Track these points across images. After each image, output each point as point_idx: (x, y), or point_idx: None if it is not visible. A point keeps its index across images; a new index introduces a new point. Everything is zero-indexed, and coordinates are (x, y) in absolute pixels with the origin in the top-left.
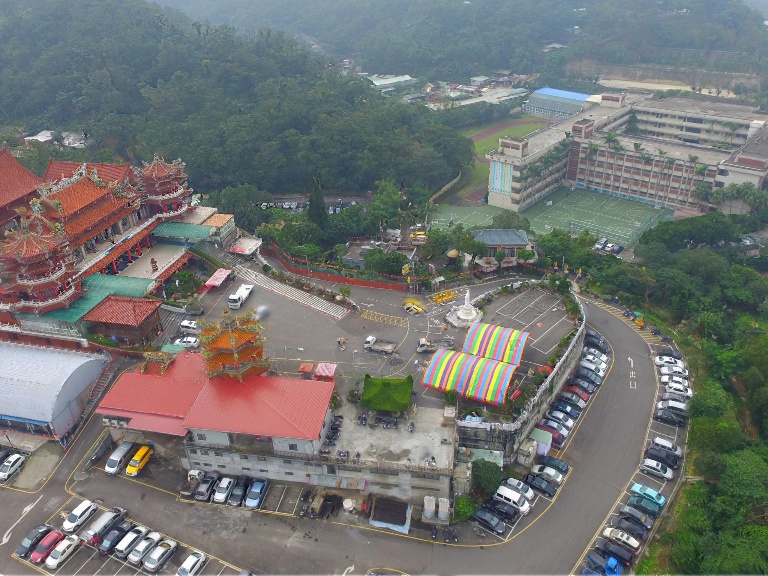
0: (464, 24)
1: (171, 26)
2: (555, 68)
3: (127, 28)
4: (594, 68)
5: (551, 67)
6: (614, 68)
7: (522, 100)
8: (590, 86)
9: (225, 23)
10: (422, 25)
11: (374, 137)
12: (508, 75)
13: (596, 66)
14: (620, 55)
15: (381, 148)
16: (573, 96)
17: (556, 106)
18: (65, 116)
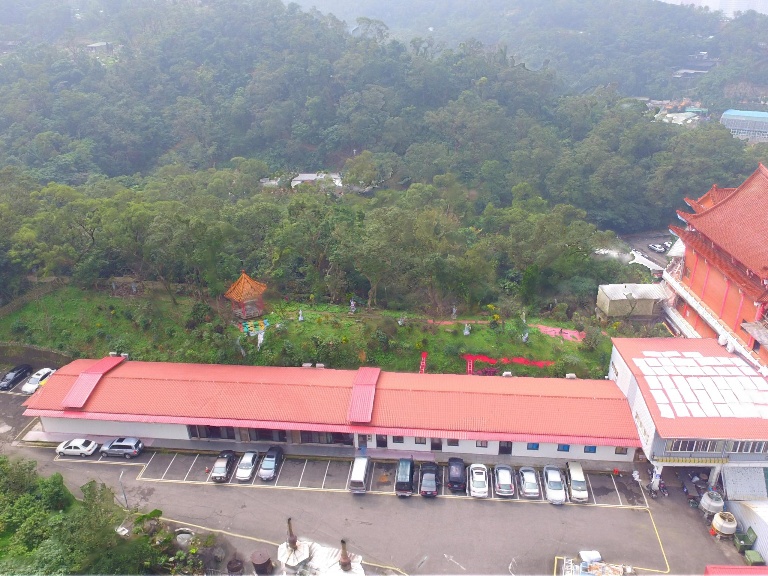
0: (588, 51)
1: (392, 42)
2: (718, 91)
3: (355, 43)
4: (749, 90)
5: (714, 90)
6: None
7: None
8: (761, 107)
9: (472, 37)
10: (539, 53)
11: (751, 157)
12: (648, 101)
13: (751, 88)
14: None
15: None
16: None
17: (761, 126)
18: None
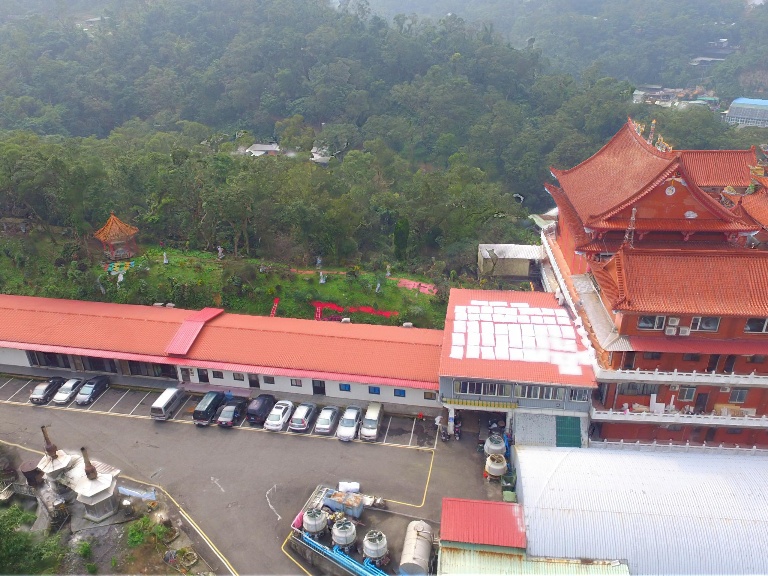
0: (600, 37)
1: (374, 18)
2: (732, 79)
3: None
4: (767, 79)
5: (728, 78)
6: None
7: (719, 111)
8: None
9: None
10: (550, 38)
11: None
12: (661, 89)
13: None
14: None
15: None
16: None
17: None
18: (269, 125)
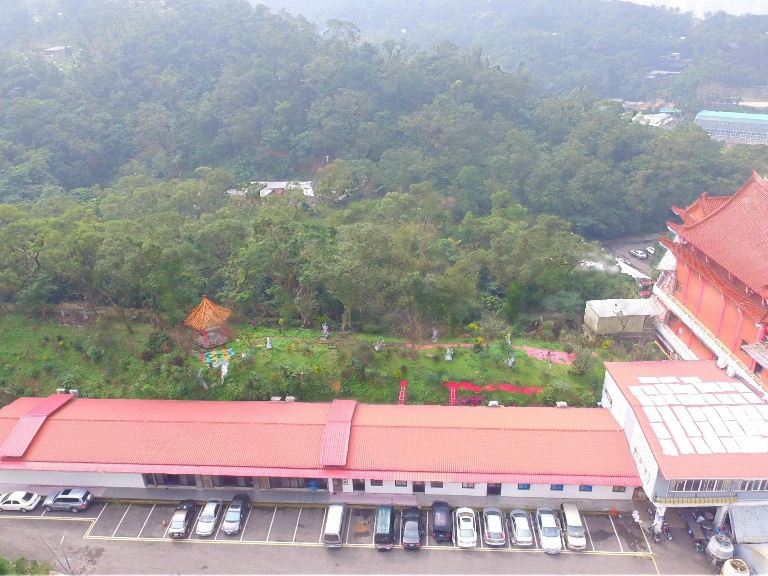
0: (561, 53)
1: (364, 45)
2: (691, 92)
3: (326, 46)
4: (722, 91)
5: (687, 91)
6: (744, 90)
7: None
8: (734, 108)
9: None
10: (512, 55)
11: (729, 159)
12: (622, 103)
13: (723, 89)
14: (752, 77)
15: (748, 171)
16: (749, 116)
17: (734, 127)
18: None
